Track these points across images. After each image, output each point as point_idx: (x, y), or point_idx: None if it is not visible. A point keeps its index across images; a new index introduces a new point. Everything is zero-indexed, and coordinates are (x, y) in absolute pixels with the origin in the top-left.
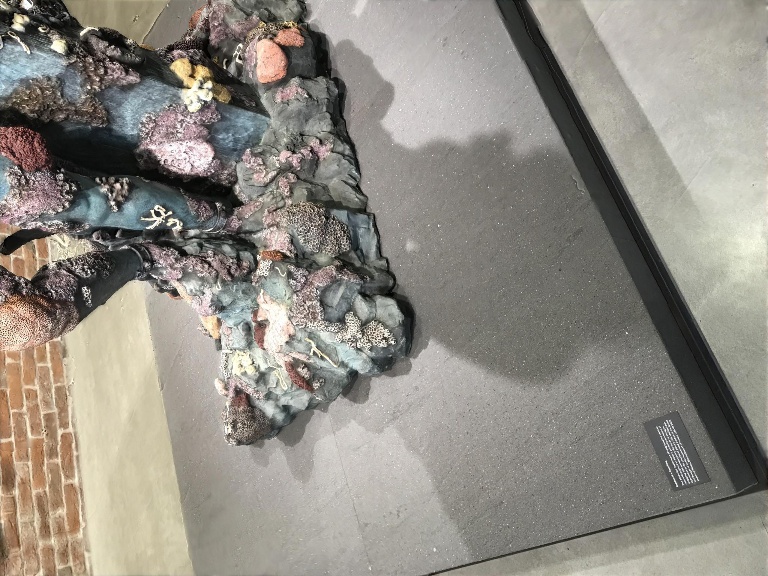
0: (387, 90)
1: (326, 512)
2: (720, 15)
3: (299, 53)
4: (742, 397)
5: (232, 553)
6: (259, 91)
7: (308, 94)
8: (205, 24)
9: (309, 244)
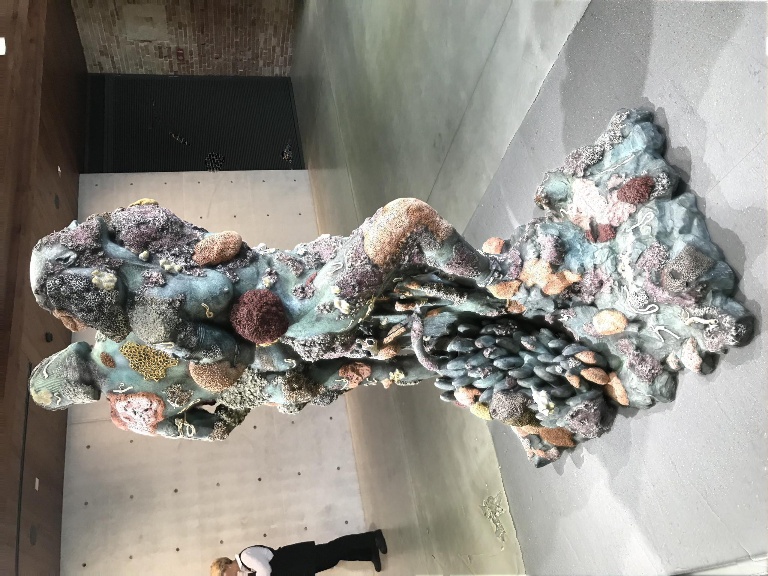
0: None
1: None
2: (562, 15)
3: None
4: None
5: None
6: None
7: None
8: None
9: None
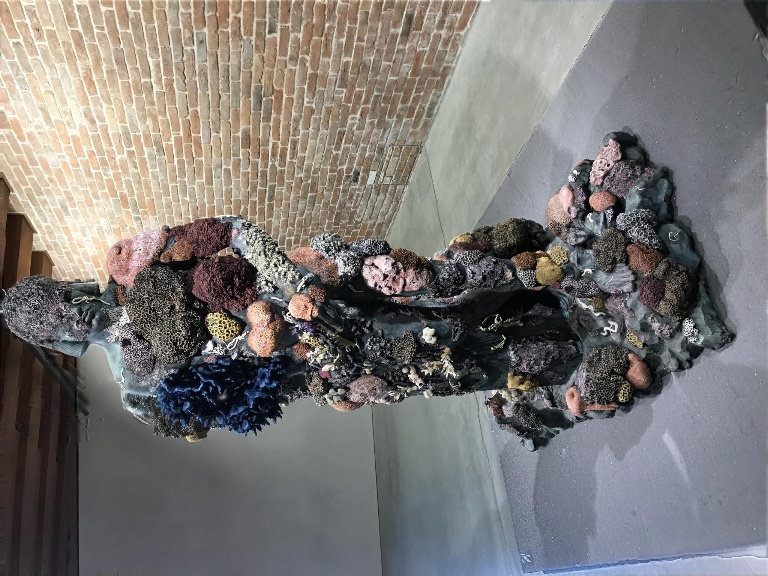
0: (621, 455)
1: None
2: None
3: None
4: (566, 575)
5: None
6: (576, 373)
7: None
8: None
9: None
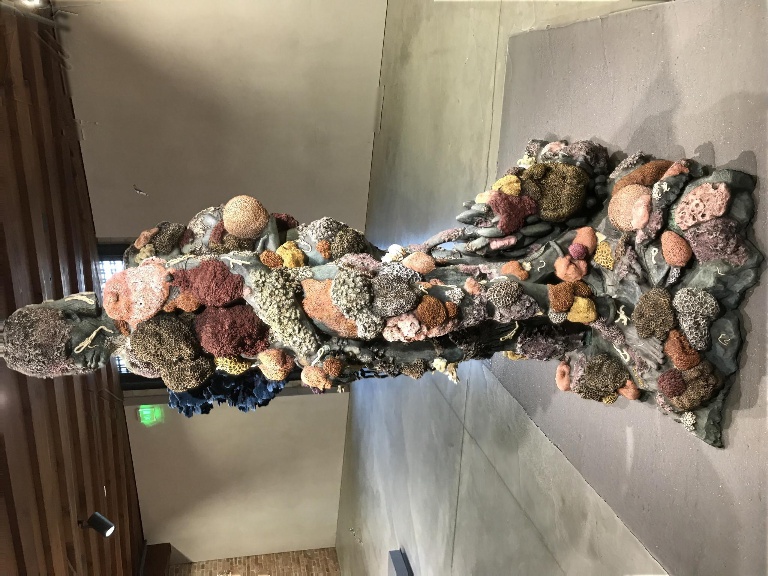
0: None
1: None
2: None
3: None
4: None
5: None
6: (576, 350)
7: None
8: None
9: None
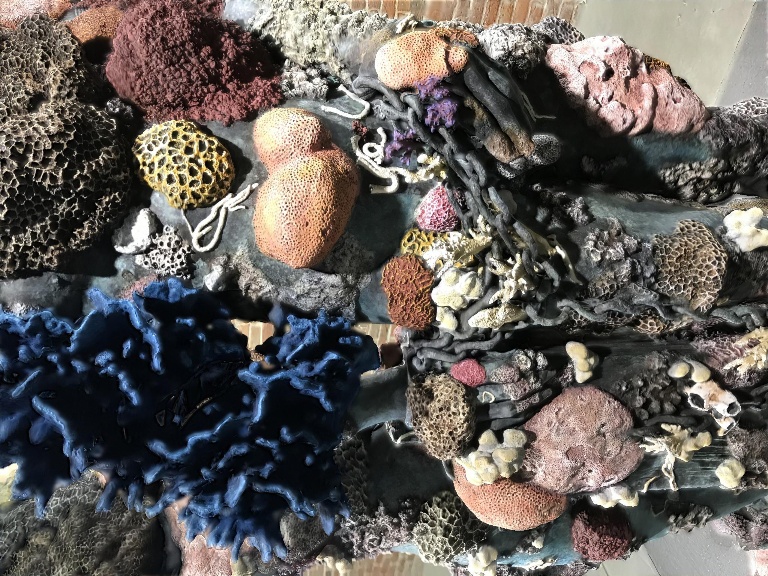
0: None
1: (710, 573)
2: None
3: None
4: None
5: None
6: None
7: None
8: None
9: None
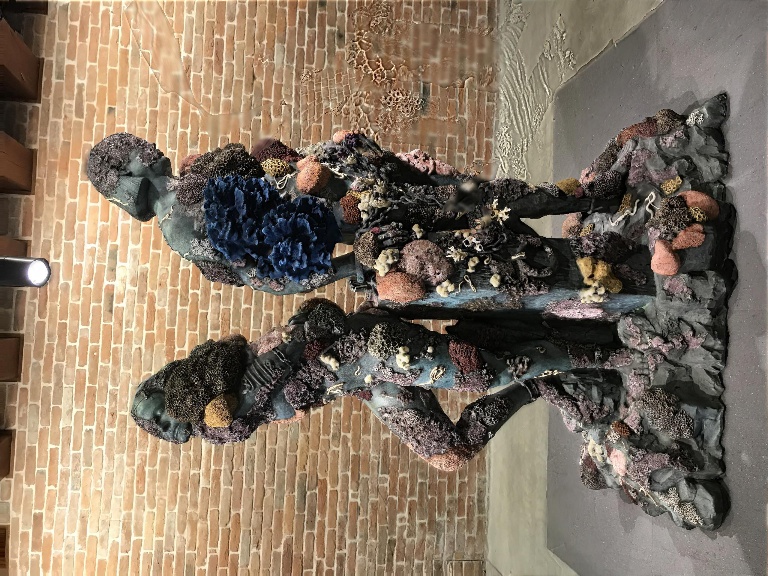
0: None
1: (634, 562)
2: None
3: (695, 252)
4: None
5: (572, 524)
6: None
7: (692, 294)
8: (627, 160)
9: (655, 425)
